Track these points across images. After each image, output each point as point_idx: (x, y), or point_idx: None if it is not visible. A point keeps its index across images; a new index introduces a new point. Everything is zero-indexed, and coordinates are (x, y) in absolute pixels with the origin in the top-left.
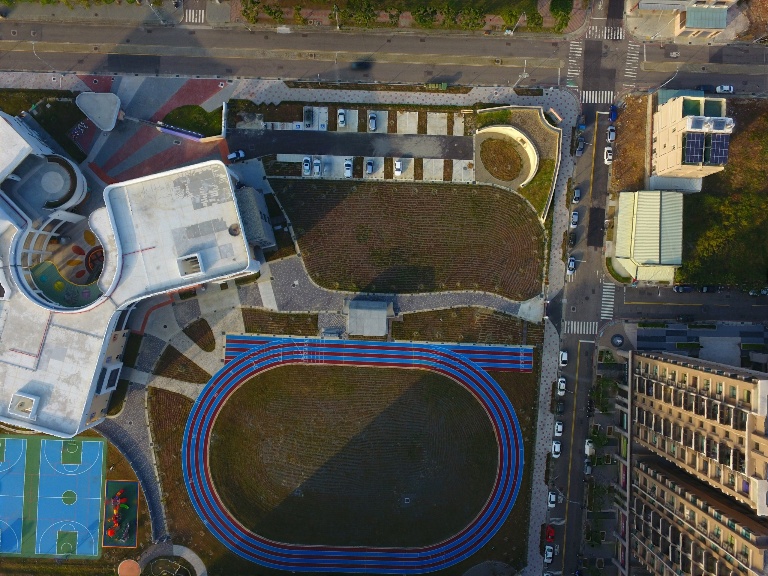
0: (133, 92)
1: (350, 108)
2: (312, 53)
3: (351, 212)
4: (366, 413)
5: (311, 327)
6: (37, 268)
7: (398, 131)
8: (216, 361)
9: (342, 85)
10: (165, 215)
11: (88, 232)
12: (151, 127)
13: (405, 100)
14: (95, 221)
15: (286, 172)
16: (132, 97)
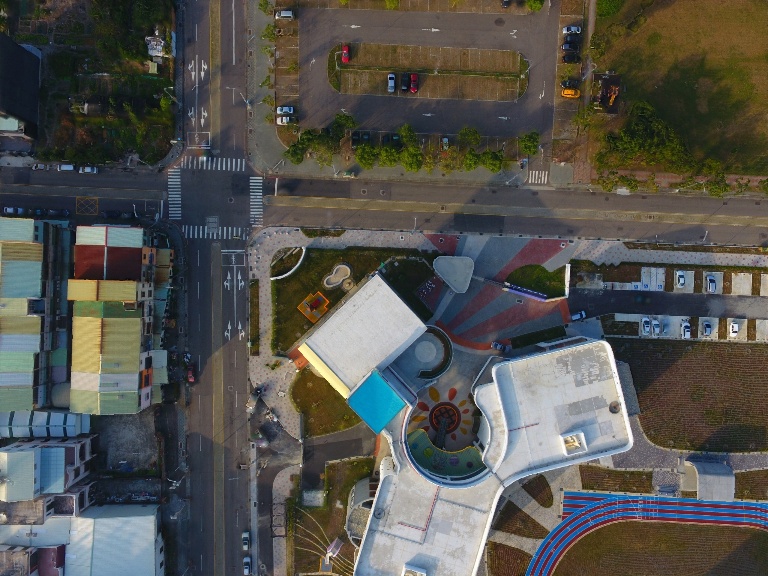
0: (478, 251)
1: (687, 269)
2: (651, 215)
3: (686, 371)
4: (696, 569)
5: (646, 484)
6: (410, 436)
7: (733, 292)
8: (554, 517)
9: (679, 247)
10: (548, 392)
11: (433, 389)
12: (495, 286)
13: (740, 262)
14: (481, 397)
15: (624, 331)
16: (477, 256)
